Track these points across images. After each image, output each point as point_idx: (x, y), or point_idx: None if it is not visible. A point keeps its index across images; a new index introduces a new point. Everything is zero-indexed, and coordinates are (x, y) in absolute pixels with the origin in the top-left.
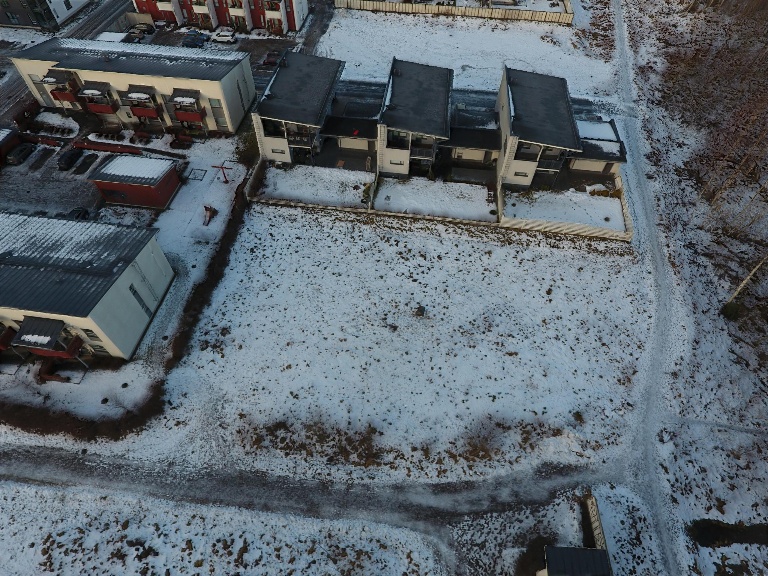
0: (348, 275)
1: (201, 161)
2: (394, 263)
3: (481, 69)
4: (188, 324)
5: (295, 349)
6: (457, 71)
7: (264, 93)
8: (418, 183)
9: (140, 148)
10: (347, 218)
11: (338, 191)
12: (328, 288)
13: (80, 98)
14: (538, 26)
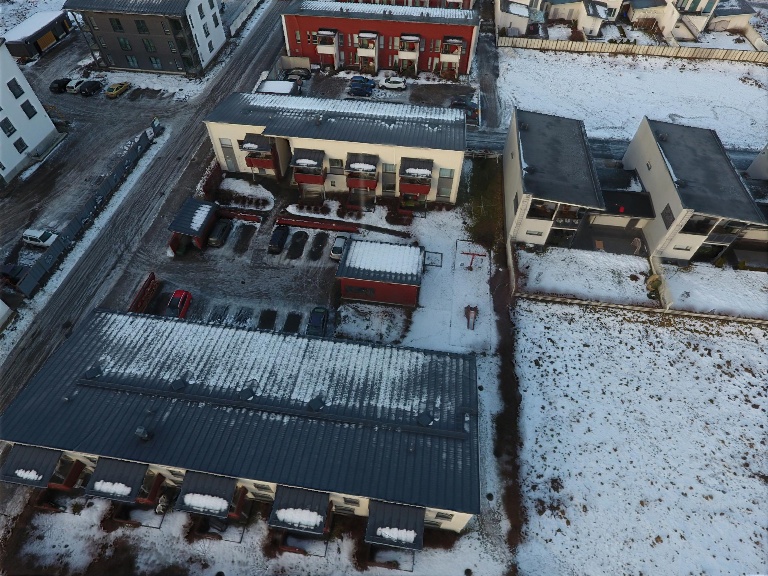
0: (670, 399)
1: (430, 241)
2: (718, 381)
3: (692, 119)
4: (510, 475)
5: (654, 511)
6: (667, 121)
7: (521, 166)
8: (704, 271)
9: (352, 224)
10: (637, 319)
11: (613, 282)
12: (653, 418)
13: (276, 164)
14: (732, 66)
